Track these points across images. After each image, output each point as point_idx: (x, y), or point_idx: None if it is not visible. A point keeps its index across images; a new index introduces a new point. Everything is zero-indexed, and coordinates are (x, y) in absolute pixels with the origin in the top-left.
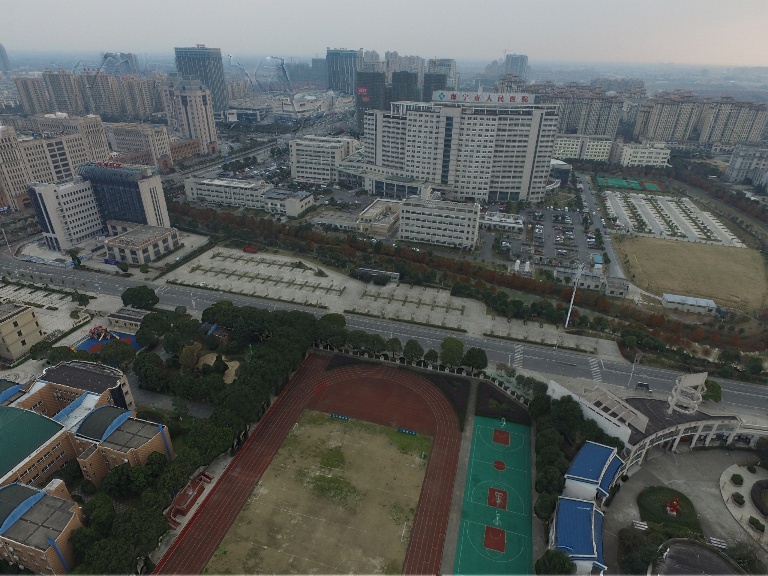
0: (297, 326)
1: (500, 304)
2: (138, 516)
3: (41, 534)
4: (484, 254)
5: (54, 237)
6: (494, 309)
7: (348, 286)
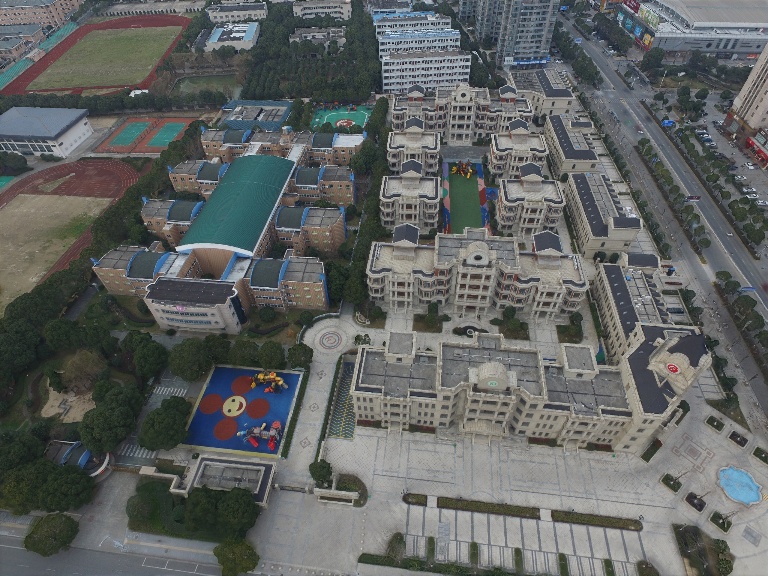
0: None
1: None
2: (101, 220)
3: (156, 205)
4: None
5: None
6: None
7: None
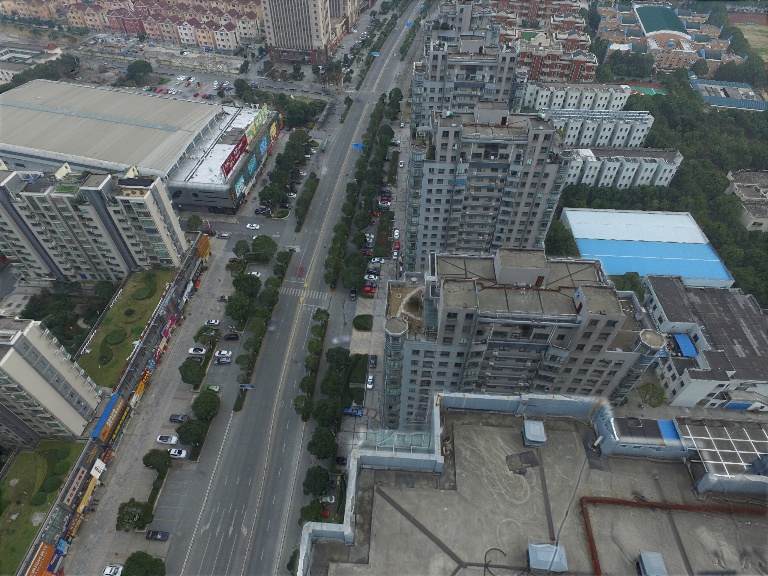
0: None
1: None
2: None
3: None
4: None
5: None
6: None
7: None
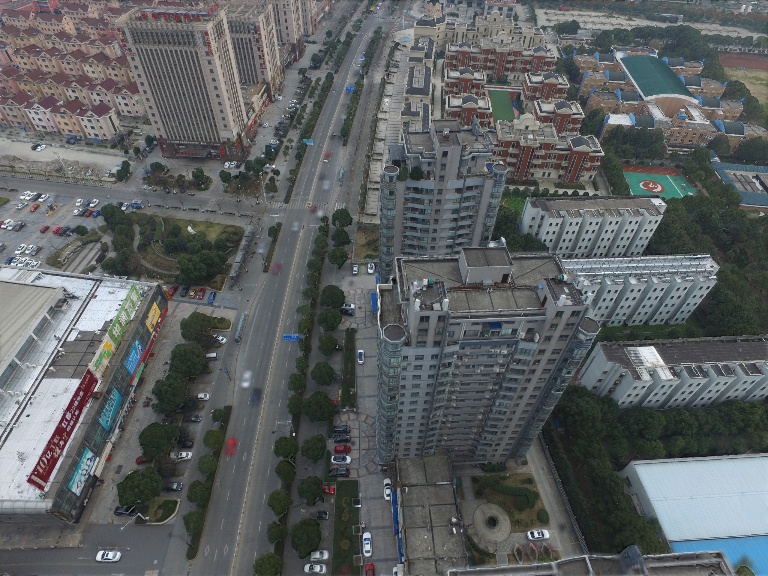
0: (693, 31)
1: (760, 25)
2: None
3: None
4: (710, 6)
5: (441, 2)
6: (756, 29)
7: (656, 24)
